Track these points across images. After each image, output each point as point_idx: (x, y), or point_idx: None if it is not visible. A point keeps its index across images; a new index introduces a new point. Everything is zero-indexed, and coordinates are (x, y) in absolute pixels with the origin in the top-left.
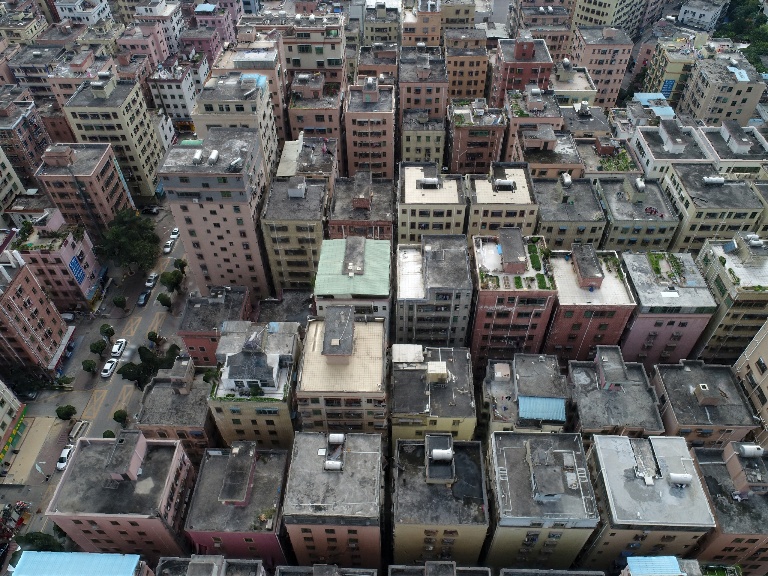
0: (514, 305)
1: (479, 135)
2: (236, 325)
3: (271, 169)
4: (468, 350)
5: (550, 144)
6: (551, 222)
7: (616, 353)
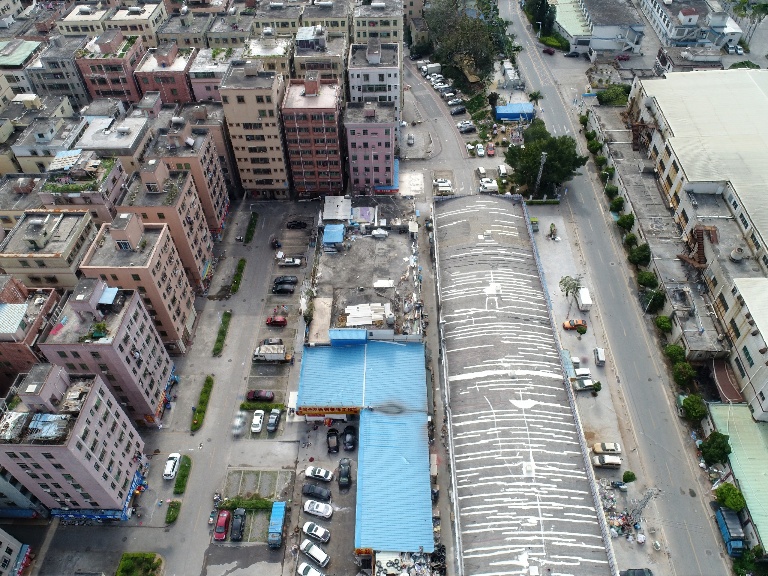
0: (104, 73)
1: (179, 2)
2: None
3: None
4: (65, 97)
5: None
6: (164, 34)
7: None
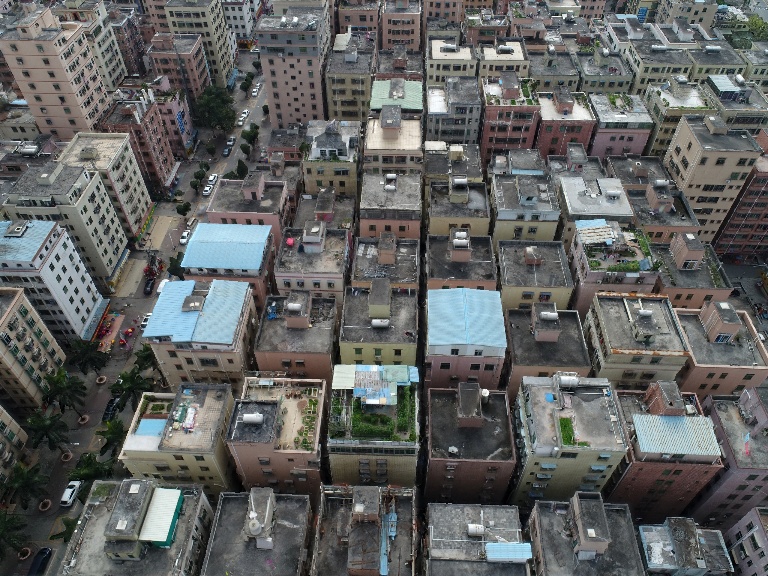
0: (510, 120)
1: (487, 34)
2: (318, 122)
3: (327, 51)
4: None
5: (541, 34)
6: (539, 76)
7: (580, 147)
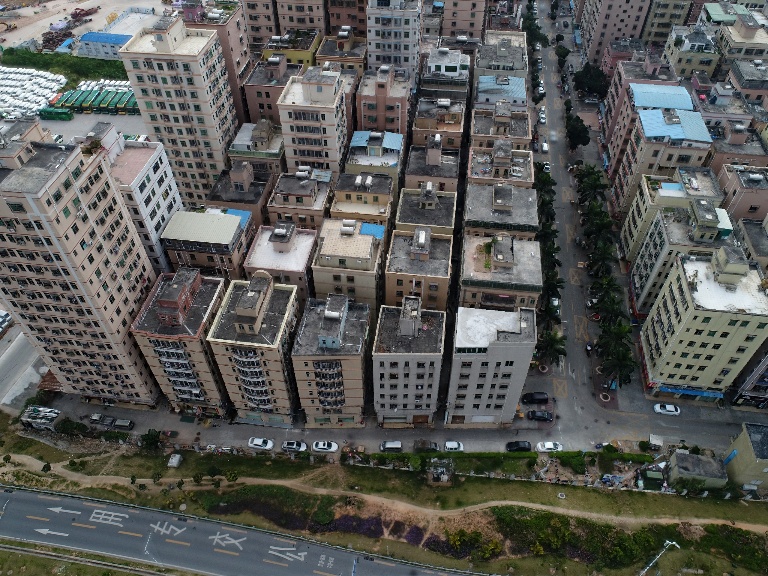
0: None
1: None
2: (680, 27)
3: None
4: None
5: None
6: None
7: None
